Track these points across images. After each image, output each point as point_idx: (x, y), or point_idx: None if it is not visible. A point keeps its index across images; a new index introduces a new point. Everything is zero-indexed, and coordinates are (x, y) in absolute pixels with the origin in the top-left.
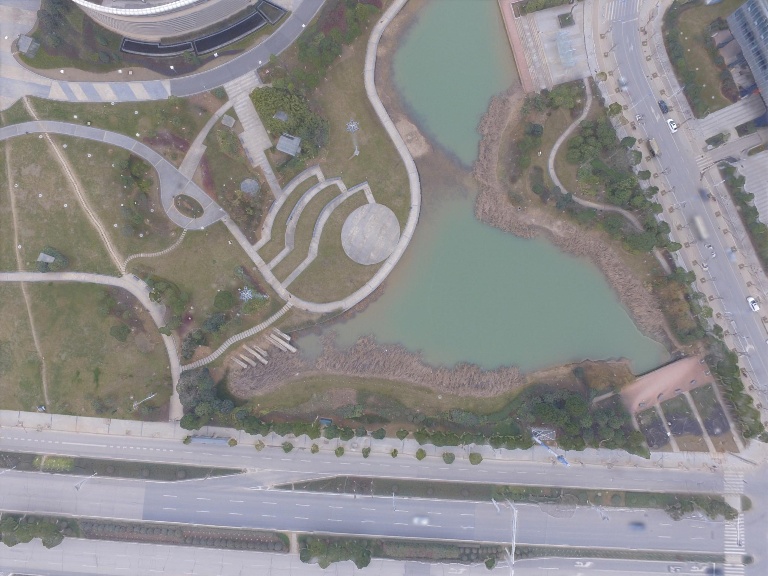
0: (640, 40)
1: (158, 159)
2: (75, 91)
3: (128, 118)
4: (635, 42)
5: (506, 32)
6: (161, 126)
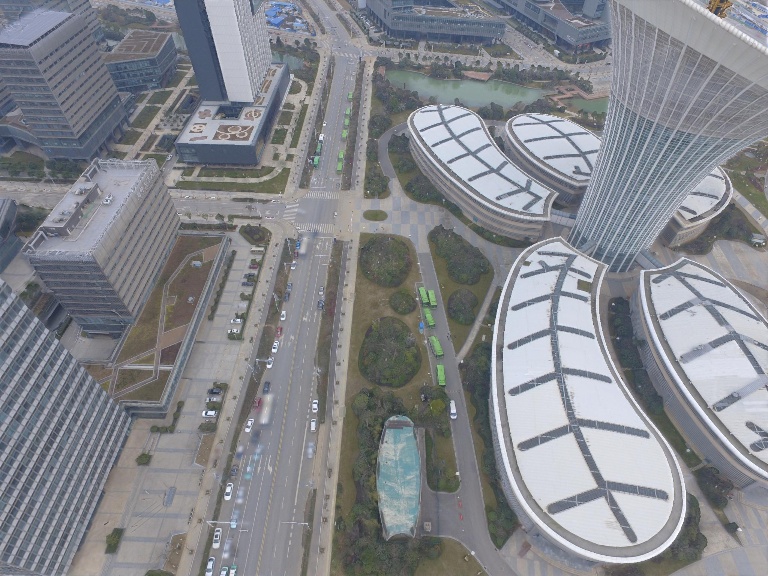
0: (584, 68)
1: (767, 187)
2: (762, 221)
3: (757, 197)
4: (585, 69)
5: (600, 98)
6: (749, 185)
